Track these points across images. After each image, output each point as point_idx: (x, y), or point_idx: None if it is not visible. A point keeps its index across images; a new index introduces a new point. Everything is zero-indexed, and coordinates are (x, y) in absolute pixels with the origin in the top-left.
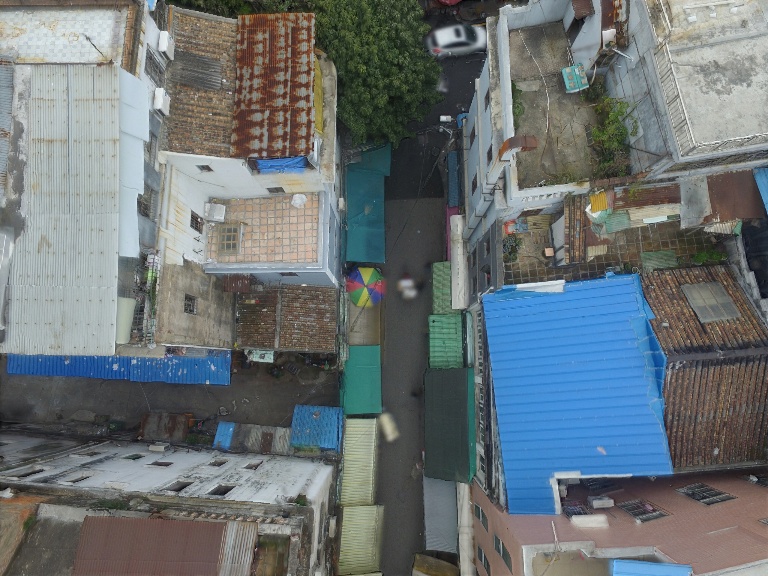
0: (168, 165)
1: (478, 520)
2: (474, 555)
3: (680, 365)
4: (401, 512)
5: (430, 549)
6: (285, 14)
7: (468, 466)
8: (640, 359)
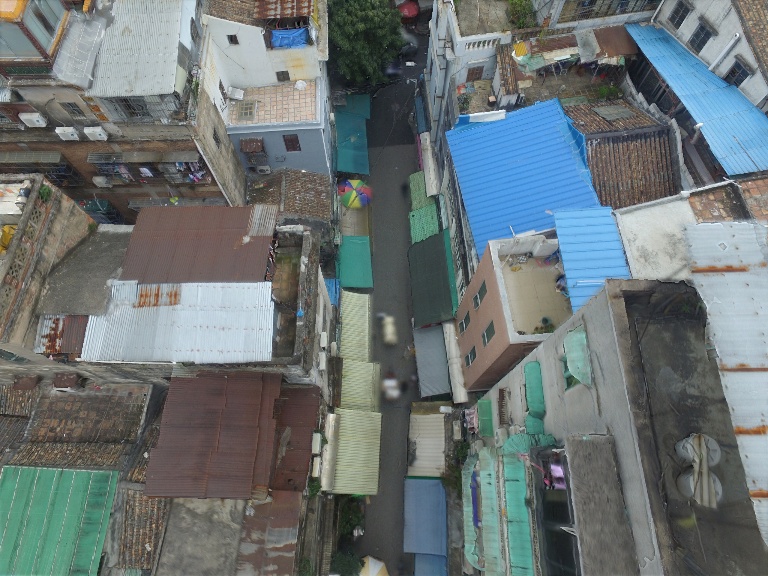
0: (208, 29)
1: (463, 340)
2: (464, 380)
3: (596, 142)
4: (396, 388)
5: (425, 396)
6: None
7: (451, 304)
8: (567, 148)
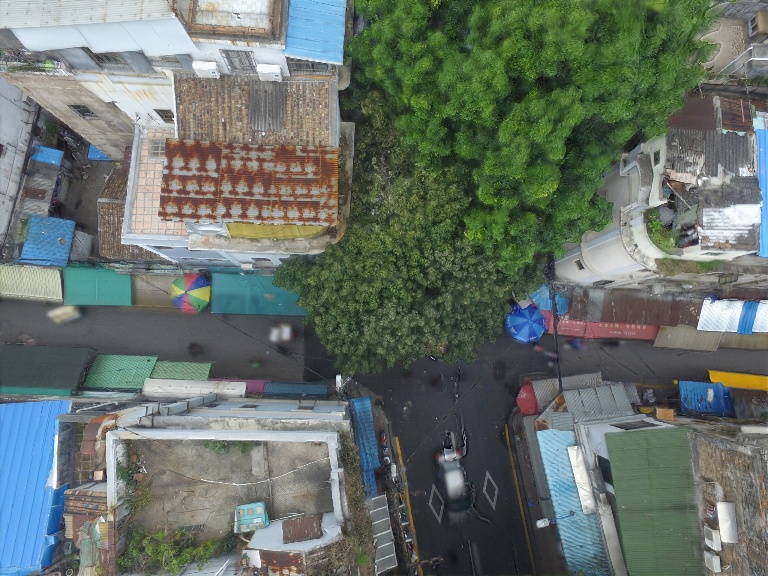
0: None
1: None
2: None
3: None
4: None
5: None
6: (337, 195)
7: None
8: None
